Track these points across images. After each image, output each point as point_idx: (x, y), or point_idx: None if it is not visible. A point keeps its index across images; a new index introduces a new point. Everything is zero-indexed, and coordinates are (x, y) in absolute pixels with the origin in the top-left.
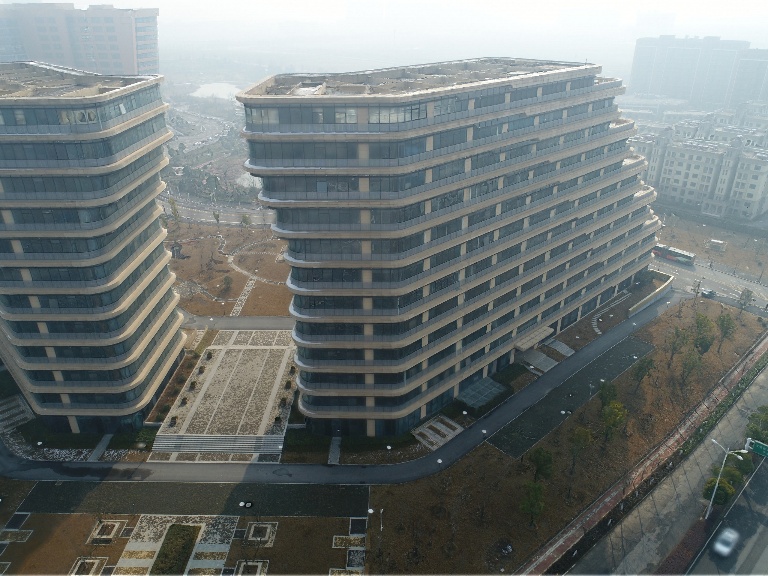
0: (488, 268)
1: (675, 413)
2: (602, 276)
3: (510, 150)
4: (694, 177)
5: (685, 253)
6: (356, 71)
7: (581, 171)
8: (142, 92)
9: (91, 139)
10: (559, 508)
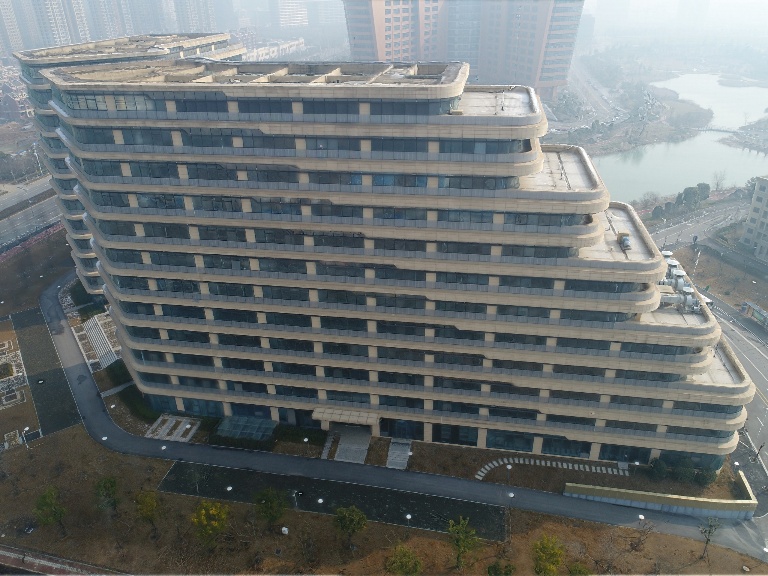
0: (248, 297)
1: None
2: (534, 410)
3: (255, 170)
4: None
5: None
6: None
7: (419, 233)
8: (122, 61)
9: (36, 89)
10: (98, 546)
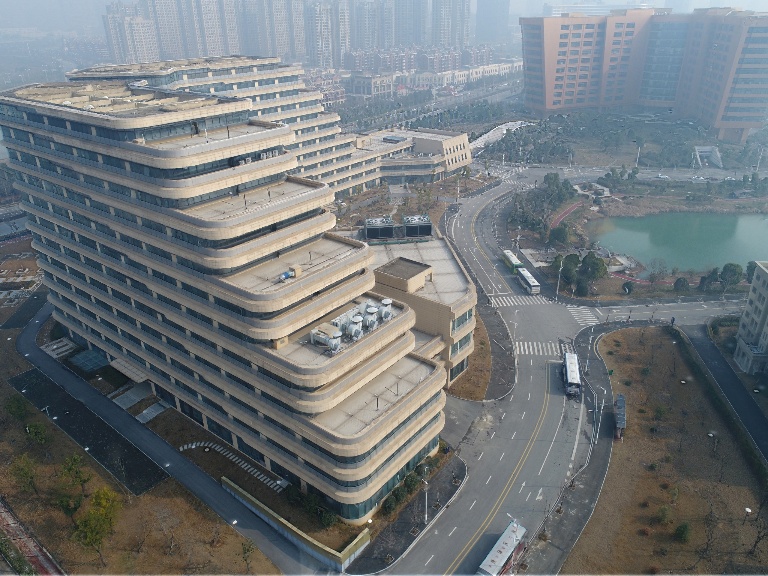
0: (79, 261)
1: (8, 487)
2: None
3: None
4: None
5: None
6: None
7: None
8: (129, 79)
9: None
10: None
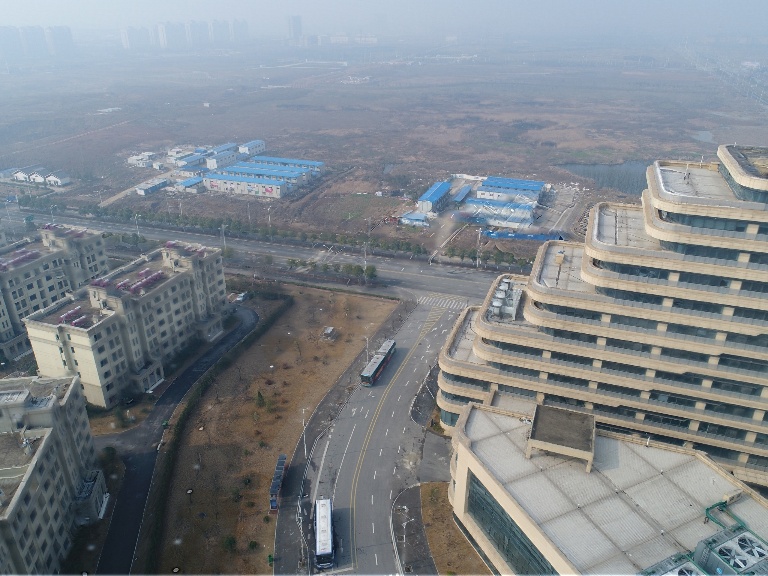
0: None
1: None
2: None
3: None
4: (177, 314)
5: (390, 344)
6: None
7: None
8: None
9: None
10: None
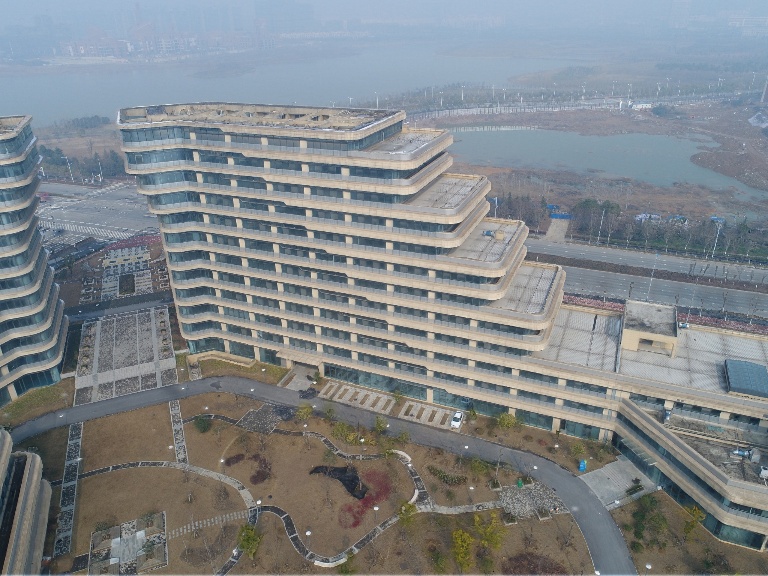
0: None
1: None
2: None
3: None
4: None
5: None
6: None
7: None
8: None
9: None
10: None
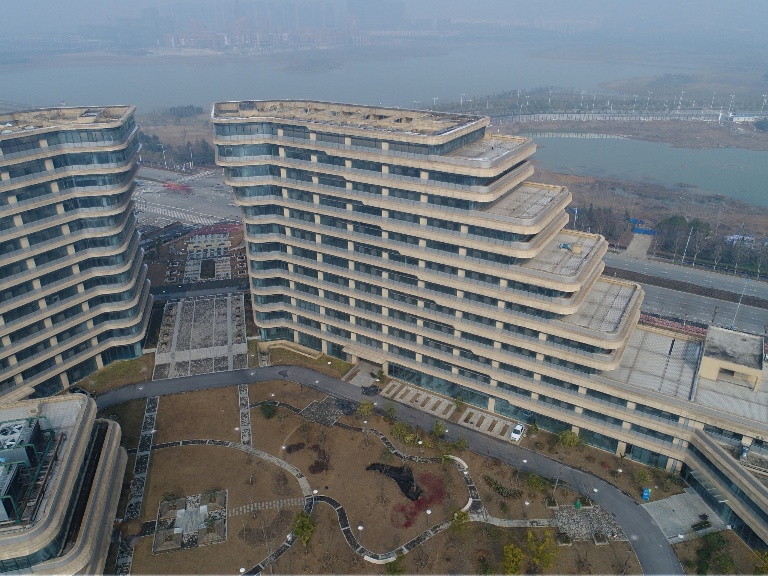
0: None
1: None
2: None
3: None
4: None
5: None
6: (41, 128)
7: None
8: None
9: None
10: None
